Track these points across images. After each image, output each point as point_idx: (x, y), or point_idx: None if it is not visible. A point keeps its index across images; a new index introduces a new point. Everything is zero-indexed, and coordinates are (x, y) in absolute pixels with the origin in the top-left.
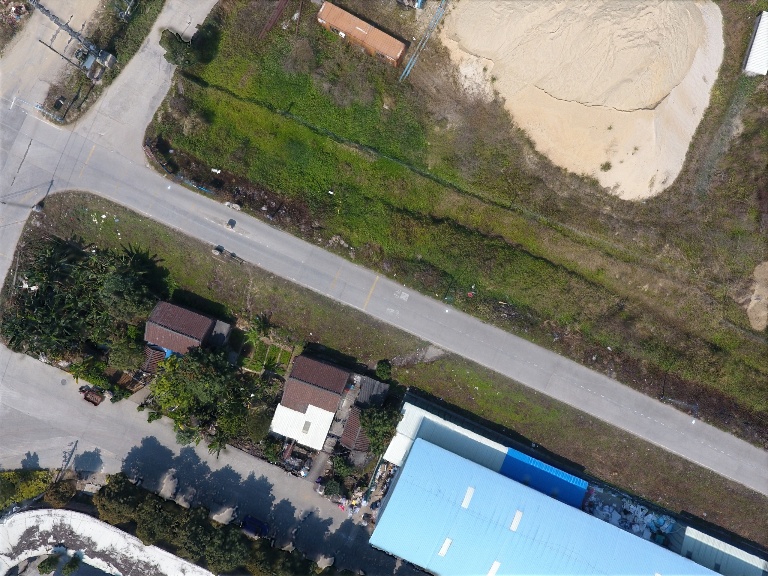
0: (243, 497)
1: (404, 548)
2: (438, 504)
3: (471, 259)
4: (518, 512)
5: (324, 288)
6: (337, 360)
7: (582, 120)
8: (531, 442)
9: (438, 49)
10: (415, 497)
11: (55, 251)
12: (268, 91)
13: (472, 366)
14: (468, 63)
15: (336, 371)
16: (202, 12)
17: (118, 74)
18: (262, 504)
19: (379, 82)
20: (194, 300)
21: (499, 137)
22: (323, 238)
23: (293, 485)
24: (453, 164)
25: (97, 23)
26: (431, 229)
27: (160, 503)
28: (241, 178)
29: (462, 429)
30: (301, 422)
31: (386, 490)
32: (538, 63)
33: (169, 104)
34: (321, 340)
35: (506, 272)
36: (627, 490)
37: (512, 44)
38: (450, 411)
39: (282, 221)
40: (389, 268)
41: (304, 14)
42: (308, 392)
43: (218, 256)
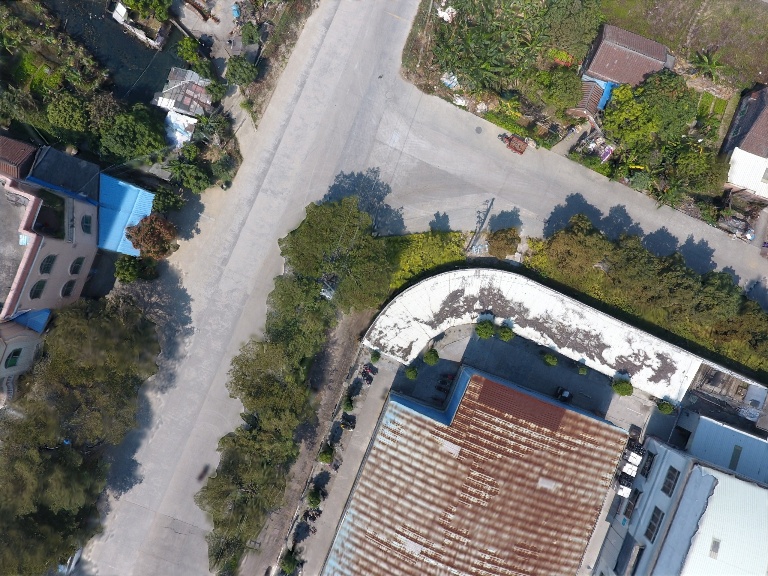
0: None
1: None
2: None
3: None
4: None
5: None
6: None
7: None
8: None
9: None
10: None
11: None
12: None
13: None
14: None
15: None
16: None
17: None
18: (702, 272)
19: None
20: None
21: None
22: None
23: (737, 250)
24: None
25: None
26: None
27: (640, 242)
28: None
29: None
30: (761, 169)
31: None
32: None
33: None
34: None
35: None
36: None
37: None
38: None
39: None
40: None
41: None
42: None
43: None
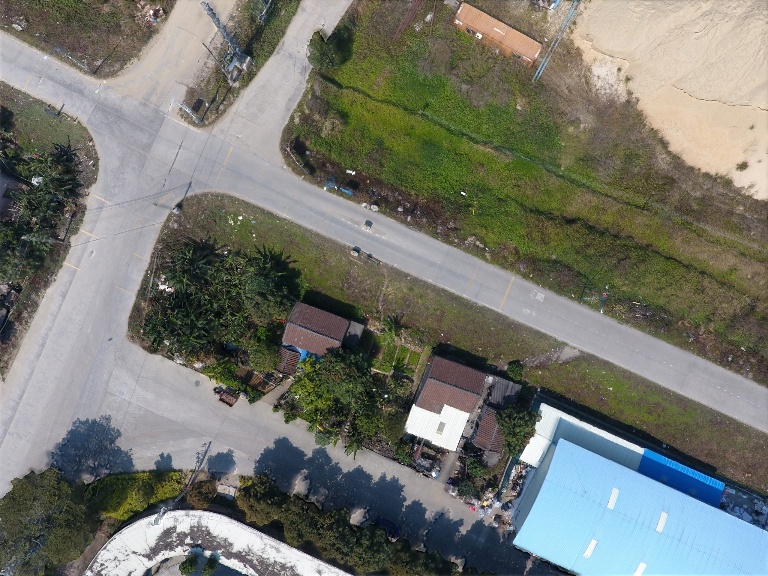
0: (374, 498)
1: (548, 549)
2: (584, 505)
3: (607, 259)
4: (663, 513)
5: (460, 289)
6: (466, 361)
7: (723, 120)
8: (662, 443)
9: (570, 50)
10: (561, 498)
11: (193, 252)
12: (403, 92)
13: (608, 367)
14: (602, 63)
15: (473, 372)
16: (336, 14)
17: (254, 76)
18: (393, 505)
19: (513, 83)
20: (325, 301)
21: (631, 137)
22: (459, 239)
23: (424, 486)
24: (589, 164)
25: (232, 26)
26: (565, 229)
27: (306, 504)
28: (375, 179)
29: (598, 430)
30: (436, 423)
31: (520, 491)
32: (679, 63)
33: (305, 106)
34: (452, 341)
35: (640, 272)
36: (759, 491)
37: (651, 44)
38: (581, 412)
39: (419, 222)
40: (525, 269)
41: (437, 15)
42: (446, 393)
43: (355, 257)
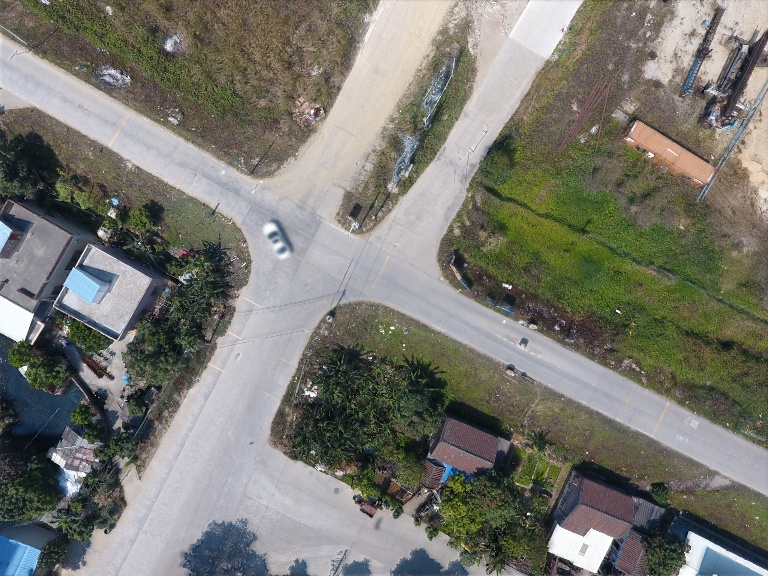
0: None
1: None
2: None
3: (764, 389)
4: None
5: (614, 412)
6: (606, 478)
7: None
8: None
9: (737, 169)
10: None
11: (344, 362)
12: (565, 207)
13: (759, 498)
14: None
15: (622, 497)
16: (499, 121)
17: (414, 183)
18: None
19: (678, 202)
20: (468, 412)
21: None
22: (616, 361)
23: None
24: (752, 292)
25: (392, 128)
26: (723, 356)
27: None
28: (531, 294)
29: (744, 561)
30: (578, 544)
31: None
32: None
33: (466, 217)
34: (596, 459)
35: None
36: None
37: None
38: (722, 537)
39: (576, 342)
40: (681, 395)
41: (604, 128)
42: (596, 518)
43: (510, 375)
